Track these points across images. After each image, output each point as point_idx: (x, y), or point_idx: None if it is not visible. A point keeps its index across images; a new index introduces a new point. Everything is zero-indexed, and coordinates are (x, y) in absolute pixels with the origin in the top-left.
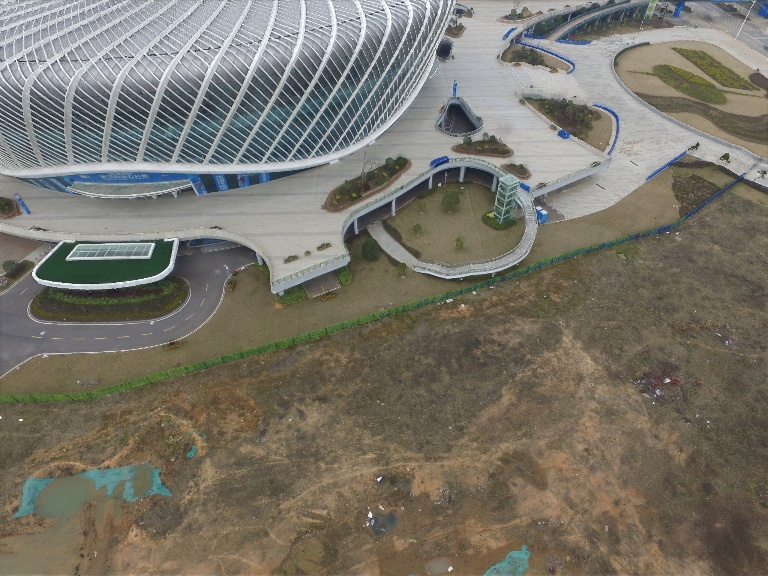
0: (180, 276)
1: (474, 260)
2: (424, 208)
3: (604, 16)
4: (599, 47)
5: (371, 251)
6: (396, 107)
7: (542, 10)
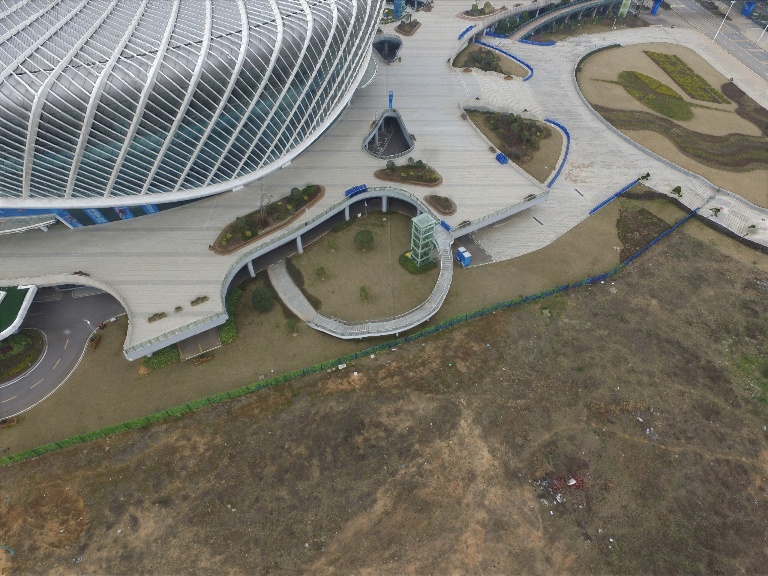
0: (39, 328)
1: (380, 313)
2: (337, 244)
3: (574, 13)
4: (564, 49)
5: (260, 302)
6: (314, 125)
7: (507, 5)
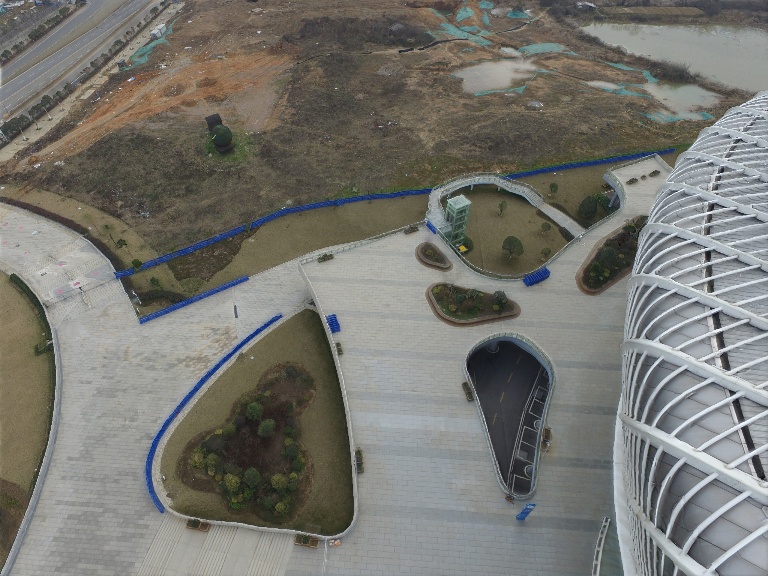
0: None
1: (486, 204)
2: None
3: None
4: None
5: None
6: None
7: None
